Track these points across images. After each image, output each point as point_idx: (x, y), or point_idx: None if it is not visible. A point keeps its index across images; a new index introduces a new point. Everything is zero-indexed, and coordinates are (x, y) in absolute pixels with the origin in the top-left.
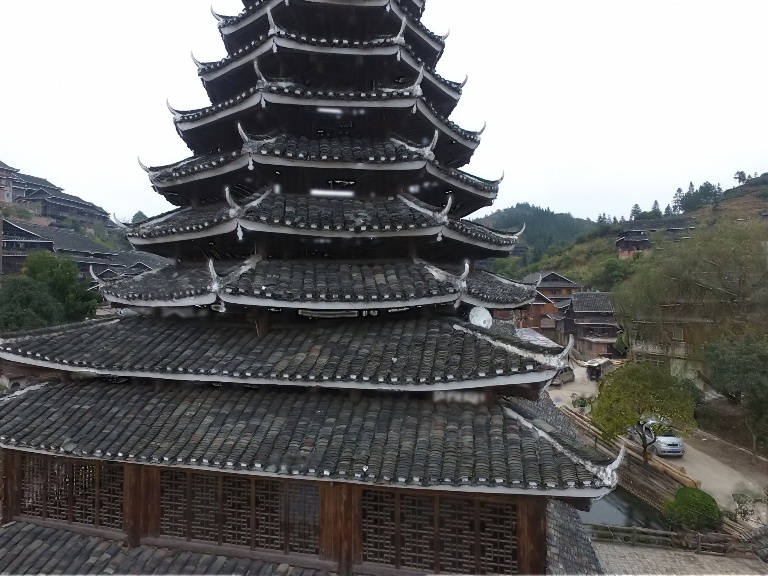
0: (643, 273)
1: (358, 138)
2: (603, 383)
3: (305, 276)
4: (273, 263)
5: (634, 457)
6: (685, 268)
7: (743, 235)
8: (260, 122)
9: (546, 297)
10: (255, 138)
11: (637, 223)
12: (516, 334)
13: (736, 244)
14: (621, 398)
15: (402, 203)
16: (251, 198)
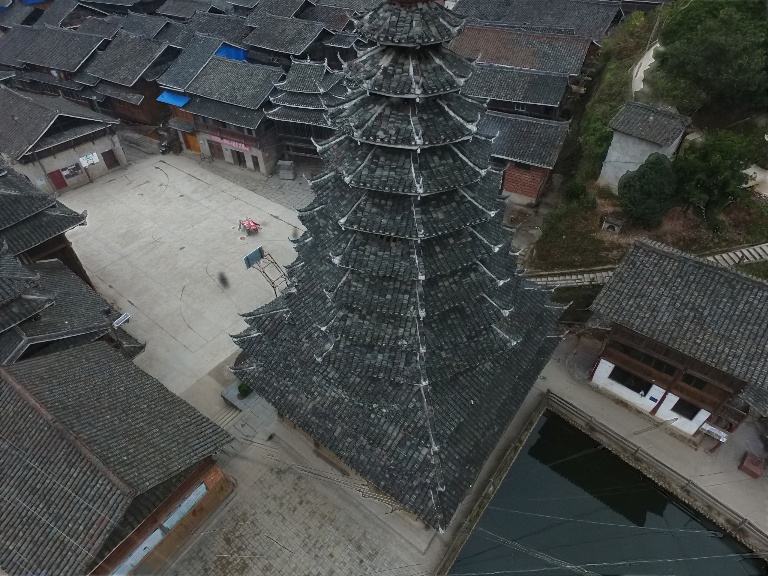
0: None
1: None
2: None
3: None
4: None
5: None
6: None
7: None
8: None
9: None
10: None
11: None
12: None
13: None
14: None
15: None
16: None
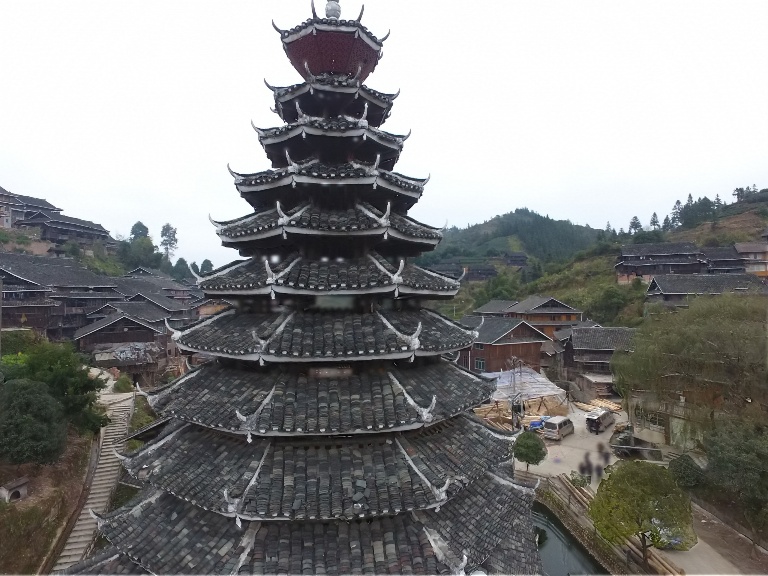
0: (642, 347)
1: (356, 374)
2: (602, 484)
3: (304, 553)
4: (272, 533)
5: (634, 551)
6: (684, 346)
7: (741, 311)
8: (258, 366)
9: (545, 335)
10: (253, 411)
11: (636, 247)
12: (515, 399)
13: (735, 327)
14: (620, 505)
15: (400, 455)
16: (250, 478)
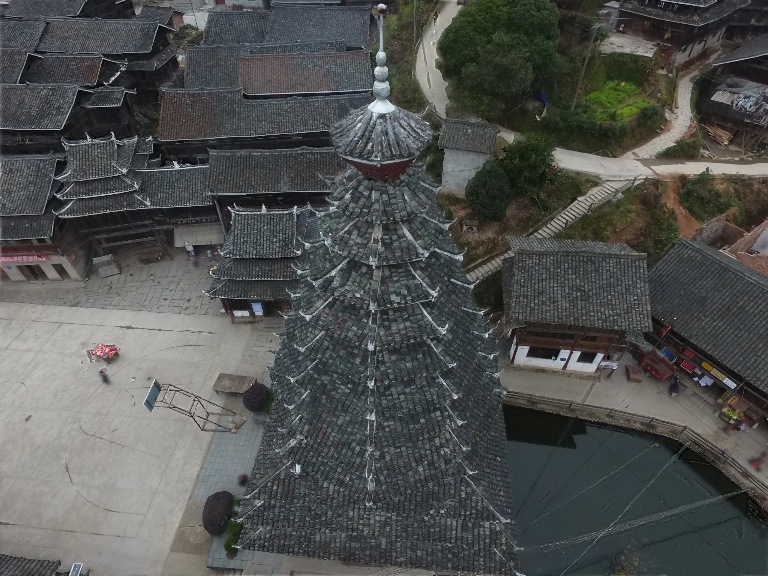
0: None
1: None
2: None
3: None
4: None
5: None
6: None
7: None
8: None
9: None
10: (283, 335)
11: None
12: None
13: None
14: None
15: None
16: None
